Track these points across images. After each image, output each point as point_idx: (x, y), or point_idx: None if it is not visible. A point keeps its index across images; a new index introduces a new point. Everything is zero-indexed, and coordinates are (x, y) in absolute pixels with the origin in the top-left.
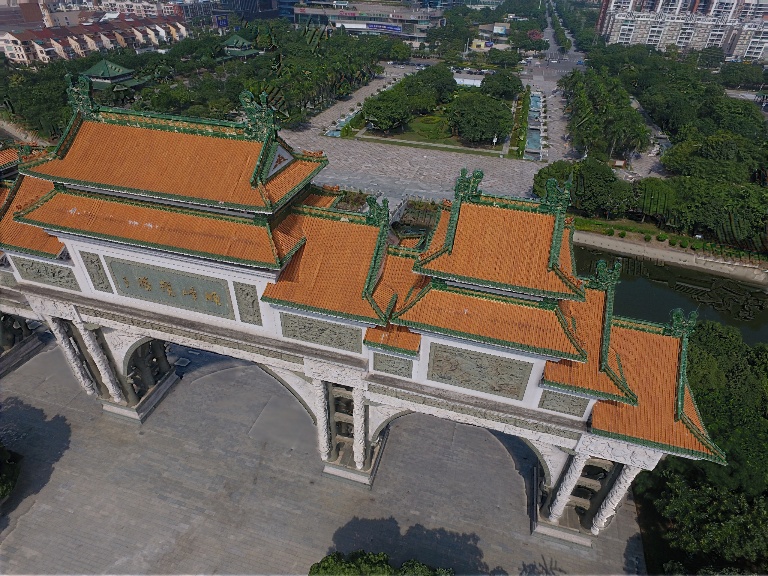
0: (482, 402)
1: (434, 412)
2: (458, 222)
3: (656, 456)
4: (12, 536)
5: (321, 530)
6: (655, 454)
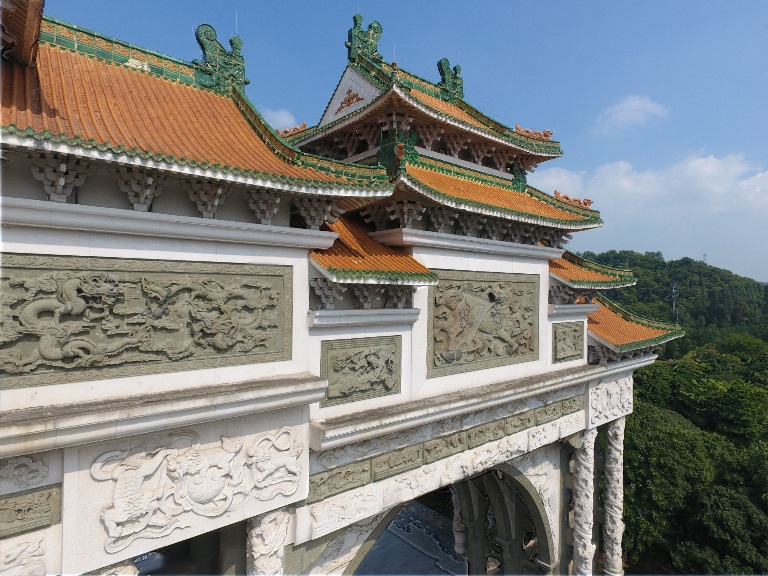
0: (510, 384)
1: (442, 474)
2: None
3: (630, 385)
4: None
5: None
6: (630, 382)
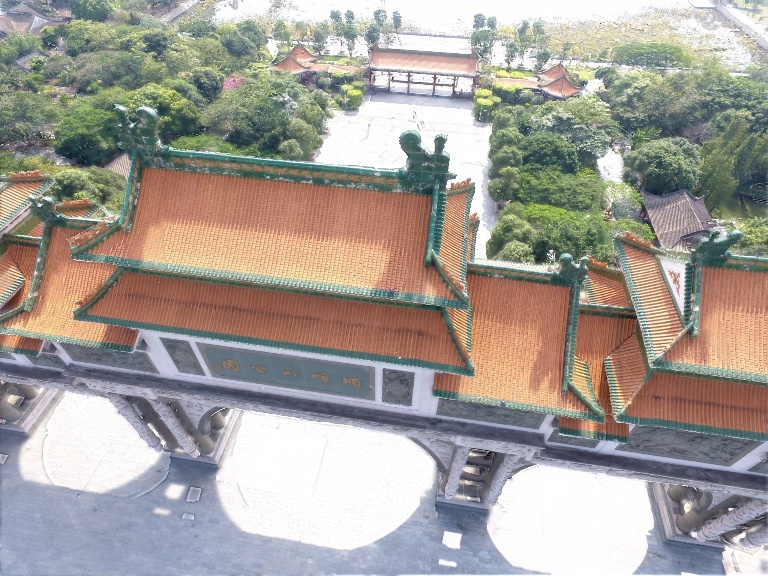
0: None
1: None
2: None
3: None
4: None
5: None
6: None
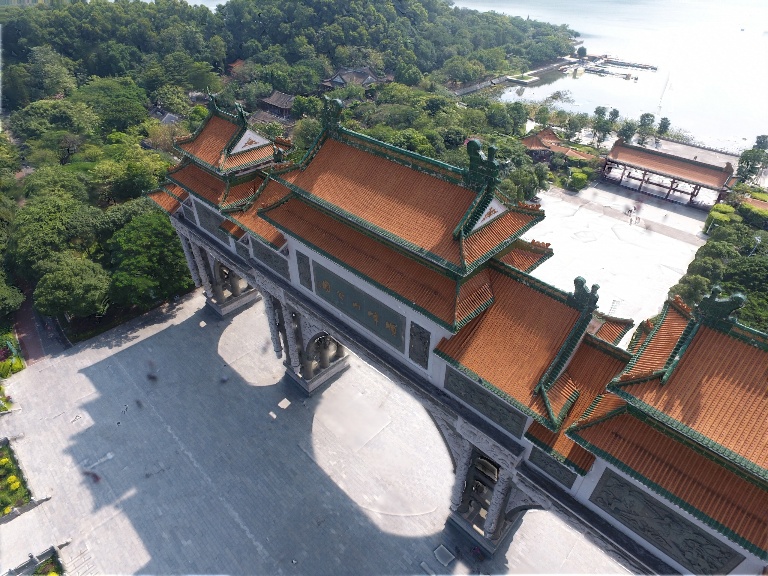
0: None
1: None
2: None
3: None
4: None
5: None
6: None
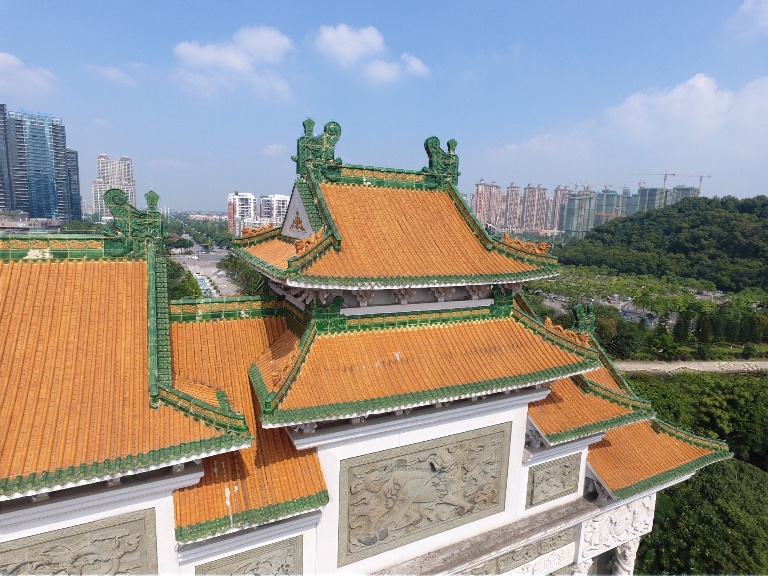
0: (452, 553)
1: None
2: None
3: (651, 503)
4: None
5: None
6: (651, 500)
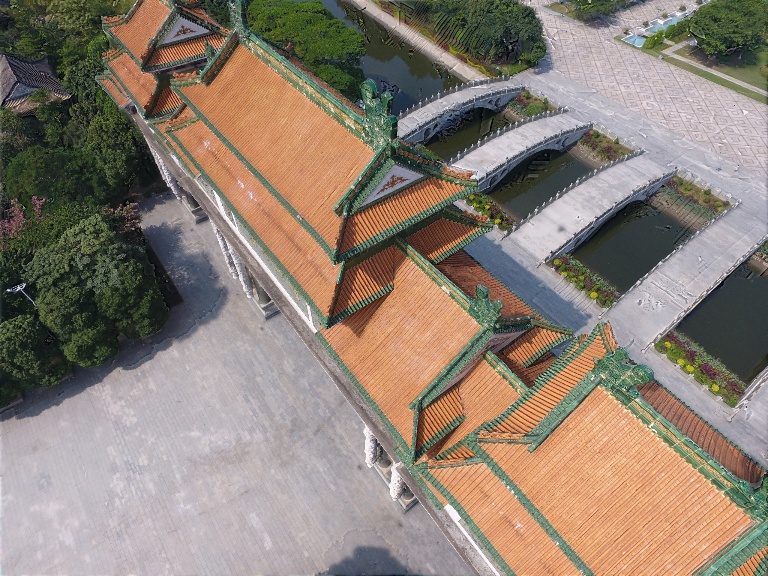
0: None
1: None
2: (574, 411)
3: None
4: (149, 364)
5: (340, 519)
6: None
